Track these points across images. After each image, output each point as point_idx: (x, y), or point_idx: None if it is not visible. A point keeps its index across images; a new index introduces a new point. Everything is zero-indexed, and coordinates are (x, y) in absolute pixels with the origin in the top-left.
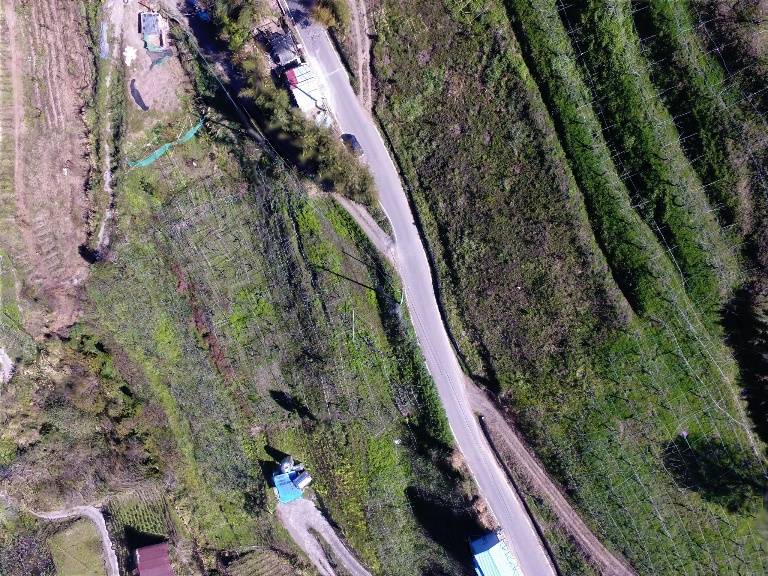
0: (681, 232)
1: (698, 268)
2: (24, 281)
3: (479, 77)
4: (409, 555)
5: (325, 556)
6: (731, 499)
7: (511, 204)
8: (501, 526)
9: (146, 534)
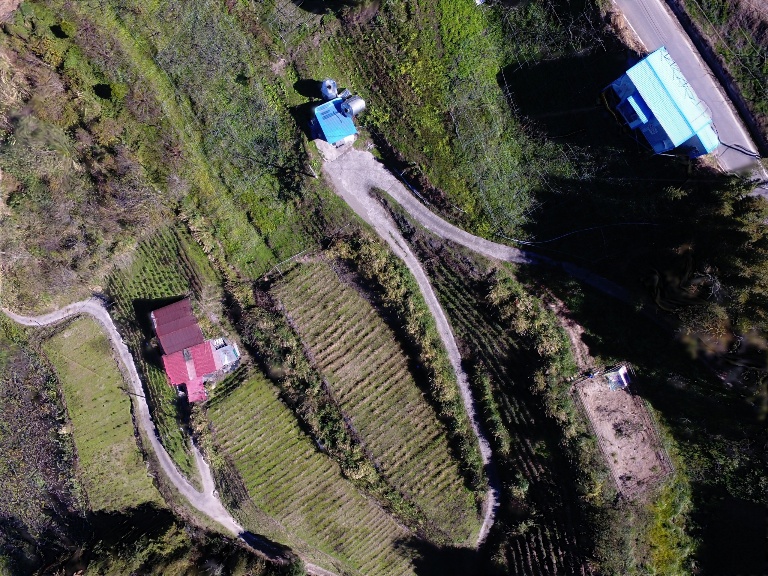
0: None
1: None
2: None
3: None
4: (514, 173)
5: (396, 227)
6: None
7: None
8: None
9: (161, 299)
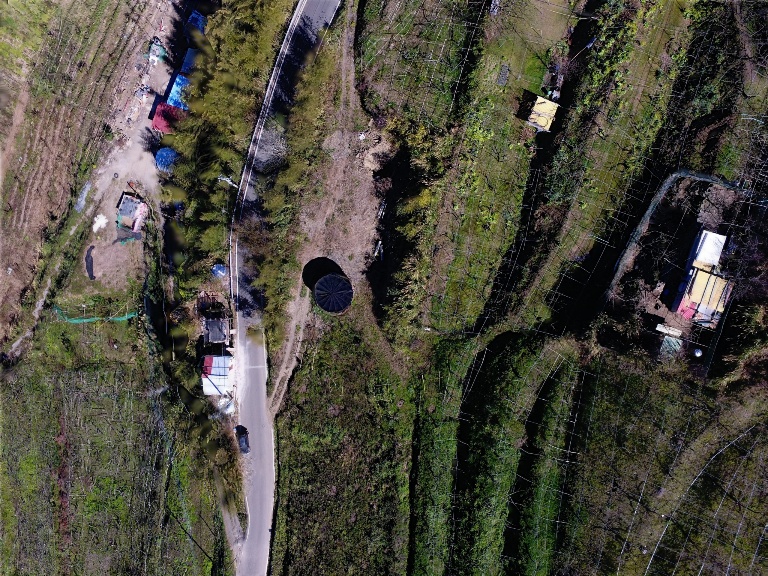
0: None
1: None
2: None
3: (369, 463)
4: None
5: None
6: None
7: None
8: None
9: None
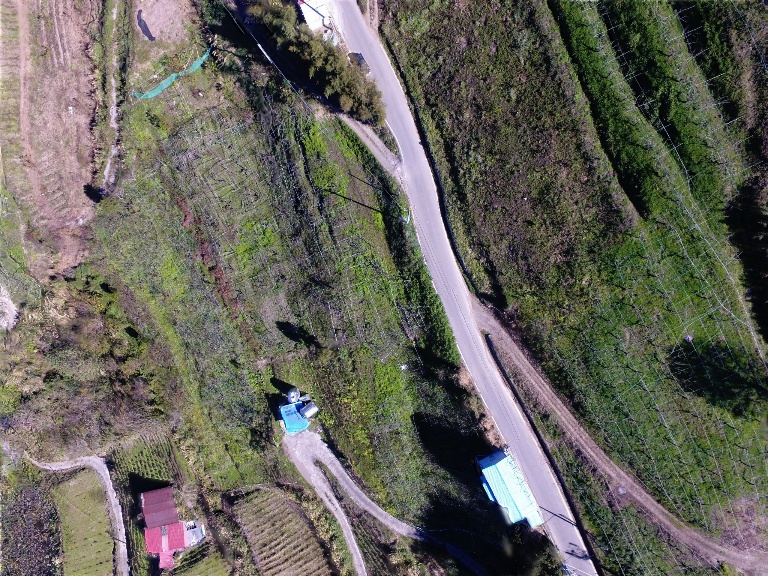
0: (686, 129)
1: (703, 165)
2: (29, 222)
3: None
4: (416, 482)
5: (331, 489)
6: (736, 403)
7: (517, 114)
8: (508, 444)
9: (151, 480)
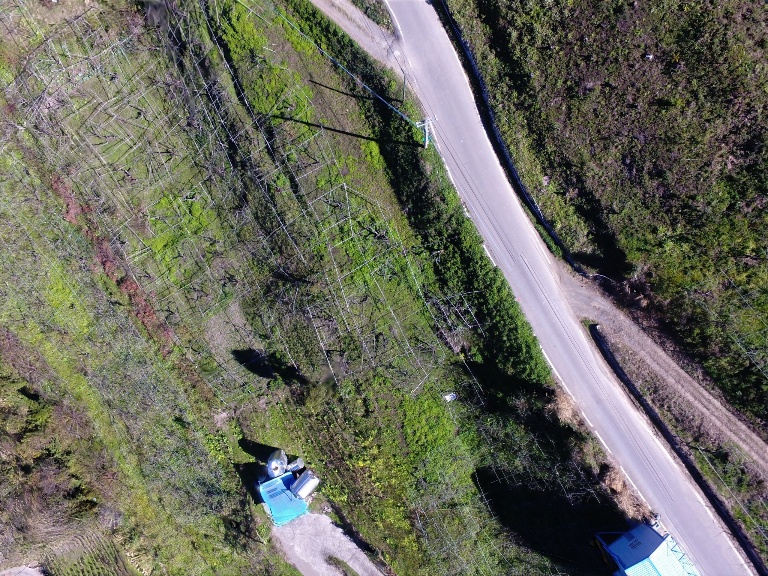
0: None
1: None
2: None
3: None
4: None
5: None
6: None
7: None
8: (654, 510)
9: None
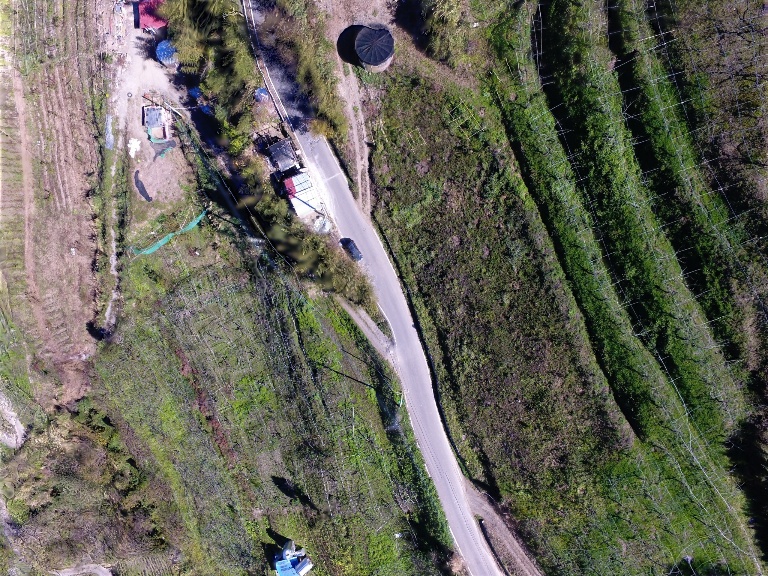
0: (684, 364)
1: (702, 400)
2: (34, 355)
3: (478, 192)
4: None
5: None
6: None
7: (510, 319)
8: None
9: None
